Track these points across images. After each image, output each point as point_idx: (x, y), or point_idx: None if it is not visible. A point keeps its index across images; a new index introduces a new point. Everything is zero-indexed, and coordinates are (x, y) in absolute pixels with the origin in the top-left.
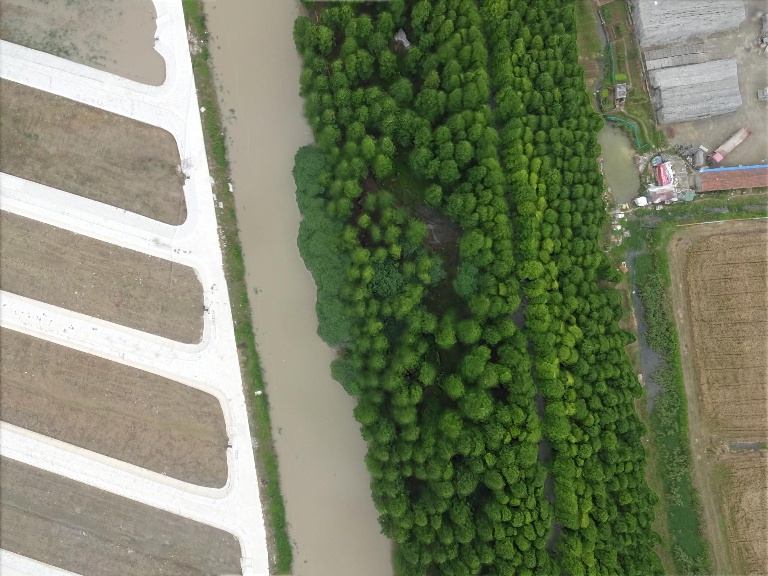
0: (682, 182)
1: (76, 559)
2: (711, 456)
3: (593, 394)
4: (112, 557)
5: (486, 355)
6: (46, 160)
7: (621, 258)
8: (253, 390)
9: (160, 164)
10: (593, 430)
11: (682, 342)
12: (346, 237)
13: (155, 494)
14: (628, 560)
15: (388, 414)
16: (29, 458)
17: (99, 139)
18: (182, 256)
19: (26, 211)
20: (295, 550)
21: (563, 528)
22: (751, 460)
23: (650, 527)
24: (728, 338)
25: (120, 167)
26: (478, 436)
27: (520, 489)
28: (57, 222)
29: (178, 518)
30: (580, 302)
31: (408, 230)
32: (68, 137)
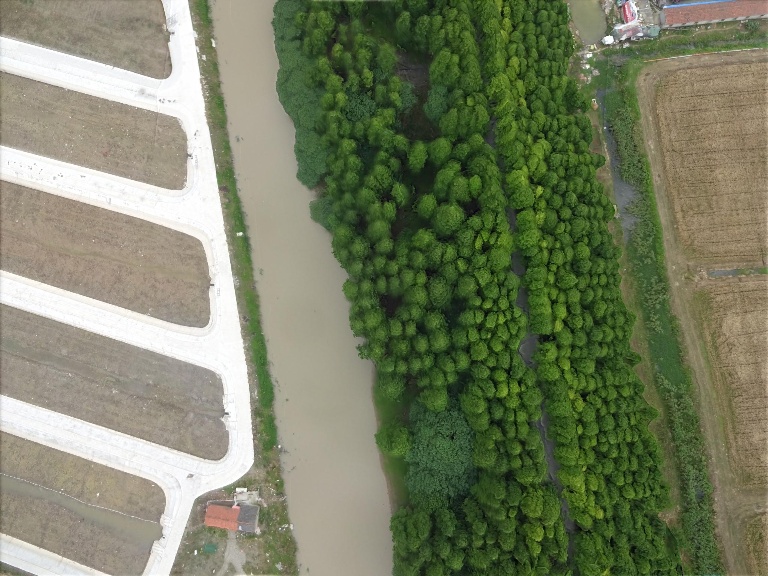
0: (646, 18)
1: (62, 400)
2: (689, 283)
3: (564, 204)
4: (97, 397)
5: (456, 165)
6: (40, 24)
7: (591, 95)
8: (235, 230)
9: (147, 24)
10: (564, 235)
11: (654, 172)
12: (319, 63)
13: (139, 332)
14: (606, 369)
15: (363, 232)
16: (18, 301)
17: (90, 3)
18: (167, 106)
19: (20, 70)
20: (277, 388)
21: (539, 338)
22: (730, 285)
23: (627, 340)
24: (700, 167)
25: (109, 28)
26: (450, 242)
27: (492, 288)
28: (49, 79)
29: (162, 357)
30: (547, 116)
31: (378, 51)
32: (61, 2)
